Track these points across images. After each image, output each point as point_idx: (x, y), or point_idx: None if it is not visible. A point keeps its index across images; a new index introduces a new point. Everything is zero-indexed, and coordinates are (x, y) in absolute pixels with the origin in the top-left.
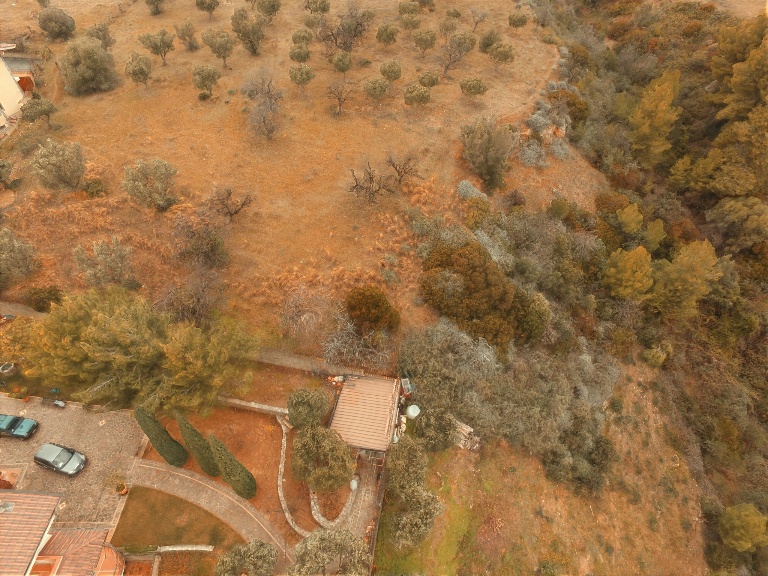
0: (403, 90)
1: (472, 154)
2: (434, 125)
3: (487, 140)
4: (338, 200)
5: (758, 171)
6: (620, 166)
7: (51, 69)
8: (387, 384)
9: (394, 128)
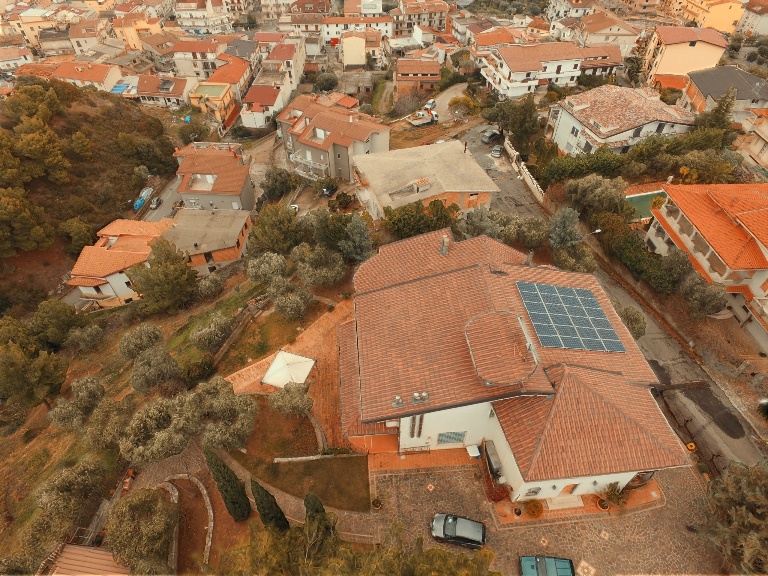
0: None
1: None
2: None
3: None
4: None
5: None
6: None
7: None
8: None
9: None
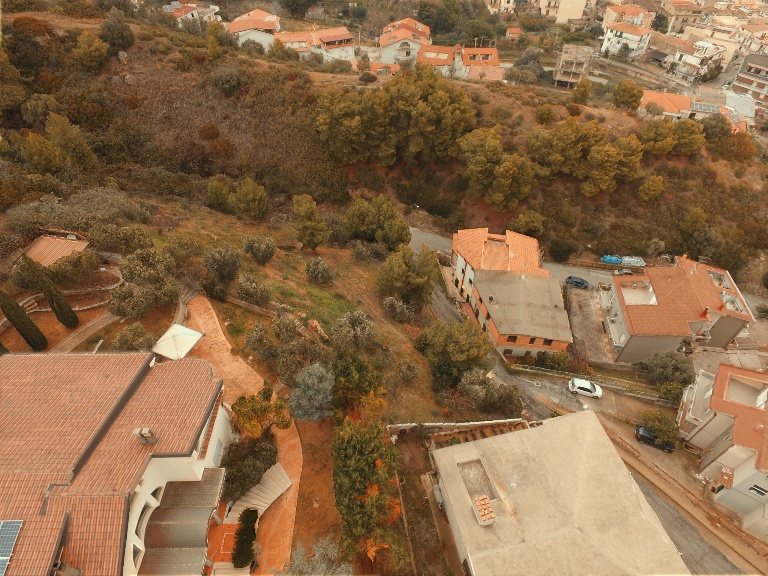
0: None
1: None
2: None
3: None
4: None
5: (14, 83)
6: None
7: None
8: (41, 241)
9: None
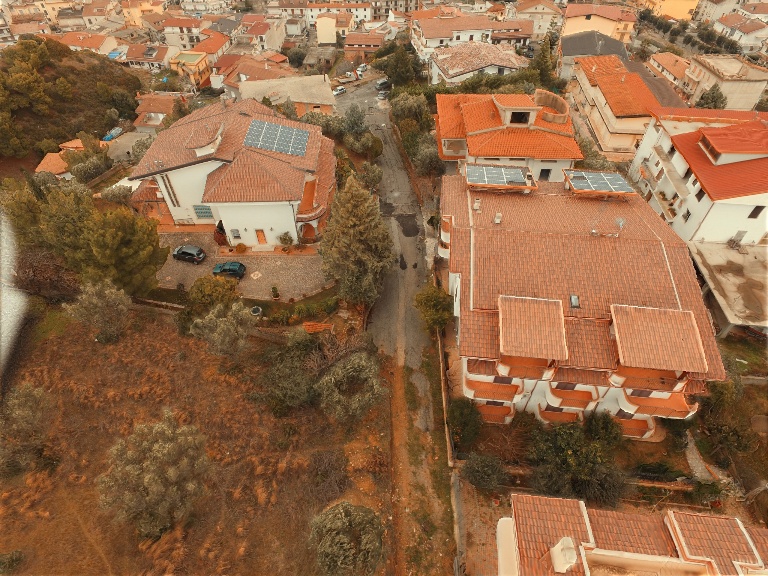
0: None
1: None
2: None
3: None
4: None
5: None
6: None
7: None
8: None
9: None
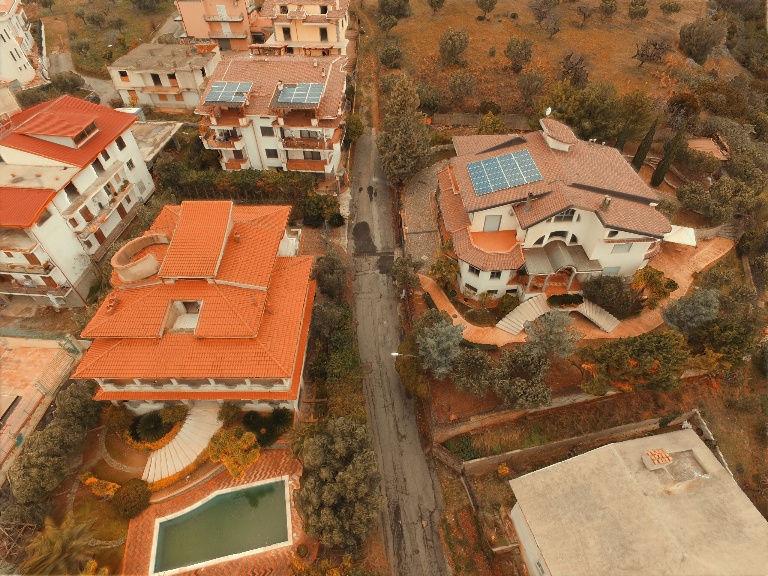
0: (631, 8)
1: (699, 39)
2: (650, 31)
3: (710, 29)
4: (619, 67)
5: None
6: (760, 65)
7: (351, 5)
8: (707, 140)
9: (625, 33)
